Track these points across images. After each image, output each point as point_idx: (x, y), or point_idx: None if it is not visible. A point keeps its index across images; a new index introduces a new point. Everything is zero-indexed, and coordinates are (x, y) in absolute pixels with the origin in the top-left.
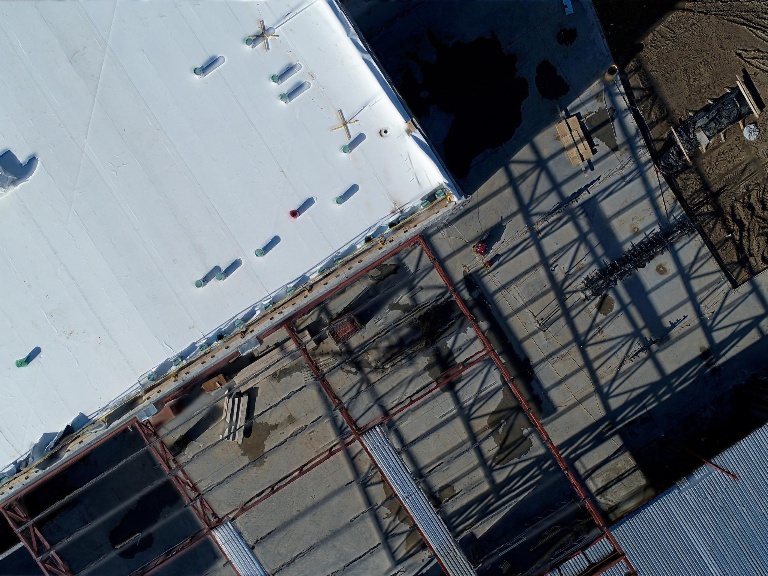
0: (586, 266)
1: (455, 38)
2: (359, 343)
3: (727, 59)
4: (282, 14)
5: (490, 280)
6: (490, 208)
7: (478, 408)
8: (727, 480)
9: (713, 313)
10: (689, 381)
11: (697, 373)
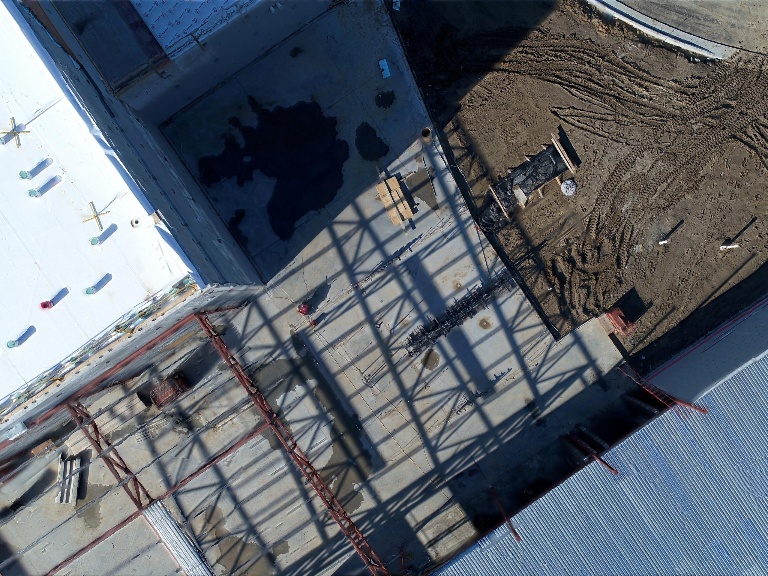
0: (411, 322)
1: (275, 103)
2: (190, 403)
3: (543, 117)
4: (32, 111)
5: (317, 338)
6: (315, 268)
7: None
8: (528, 537)
9: (537, 365)
10: (515, 433)
11: (523, 425)
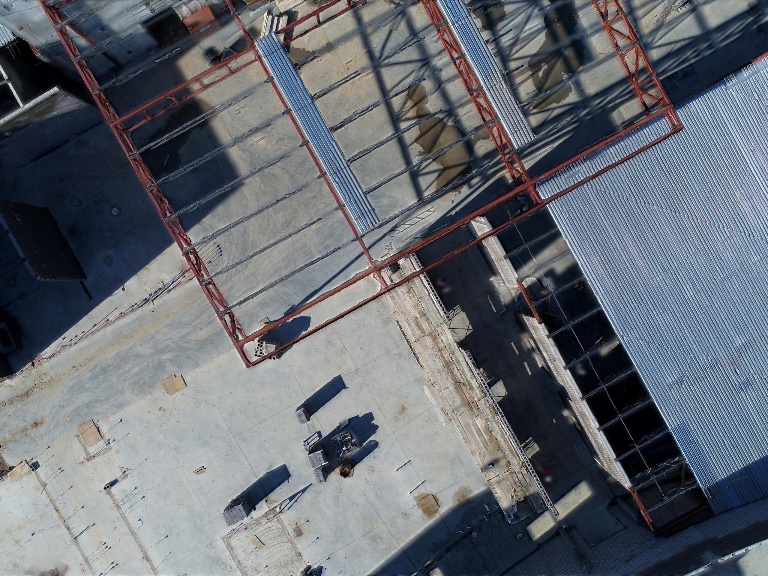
0: None
1: None
2: None
3: None
4: None
5: None
6: None
7: (519, 49)
8: None
9: None
10: (735, 36)
11: (743, 29)
